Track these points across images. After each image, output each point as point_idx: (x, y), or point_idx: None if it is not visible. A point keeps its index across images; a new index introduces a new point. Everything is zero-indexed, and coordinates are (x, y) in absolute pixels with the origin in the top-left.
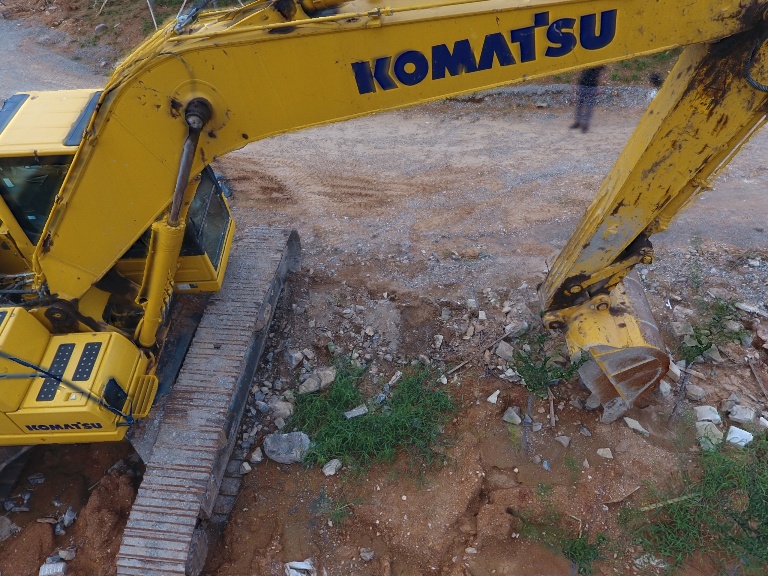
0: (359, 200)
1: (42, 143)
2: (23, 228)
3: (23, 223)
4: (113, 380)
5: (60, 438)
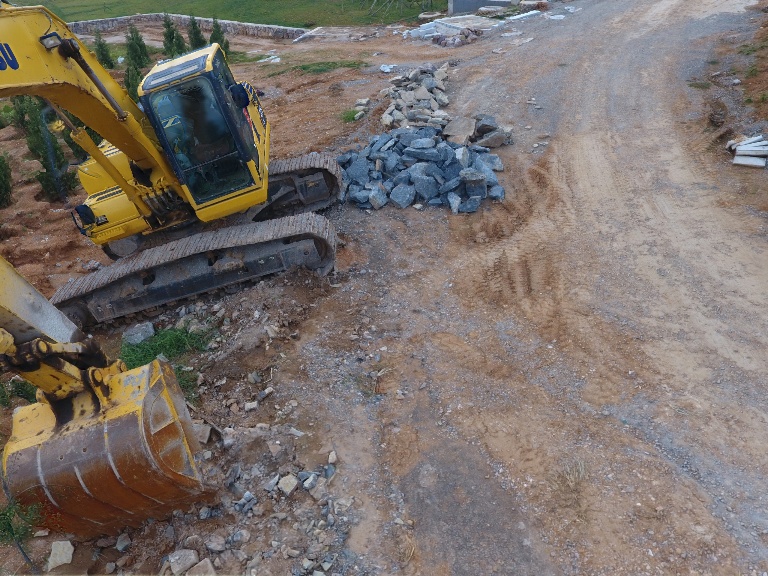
0: (497, 285)
1: None
2: None
3: None
4: (87, 206)
5: None
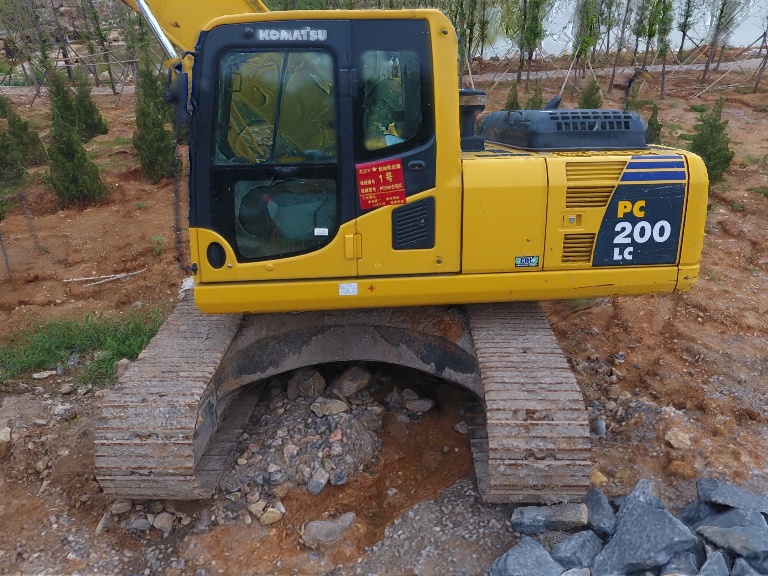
0: None
1: None
2: None
3: None
4: None
5: None
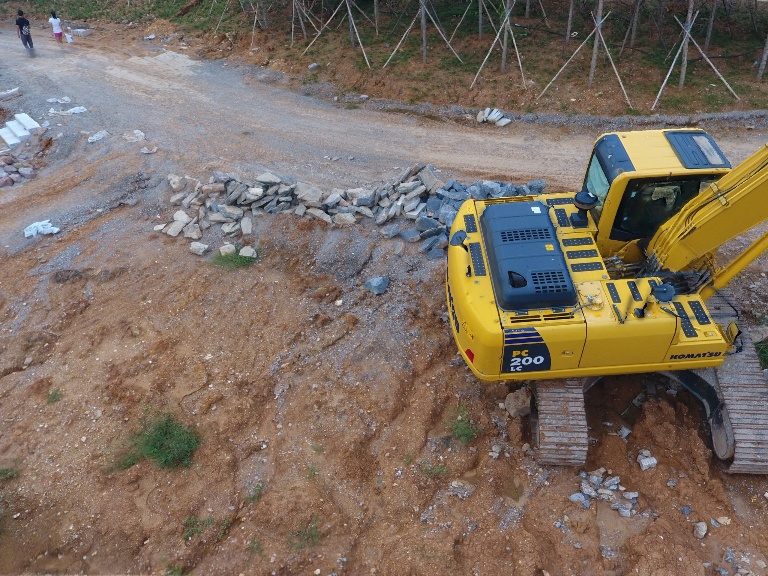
0: None
1: (670, 167)
2: (613, 226)
3: (617, 223)
4: None
5: (683, 365)
